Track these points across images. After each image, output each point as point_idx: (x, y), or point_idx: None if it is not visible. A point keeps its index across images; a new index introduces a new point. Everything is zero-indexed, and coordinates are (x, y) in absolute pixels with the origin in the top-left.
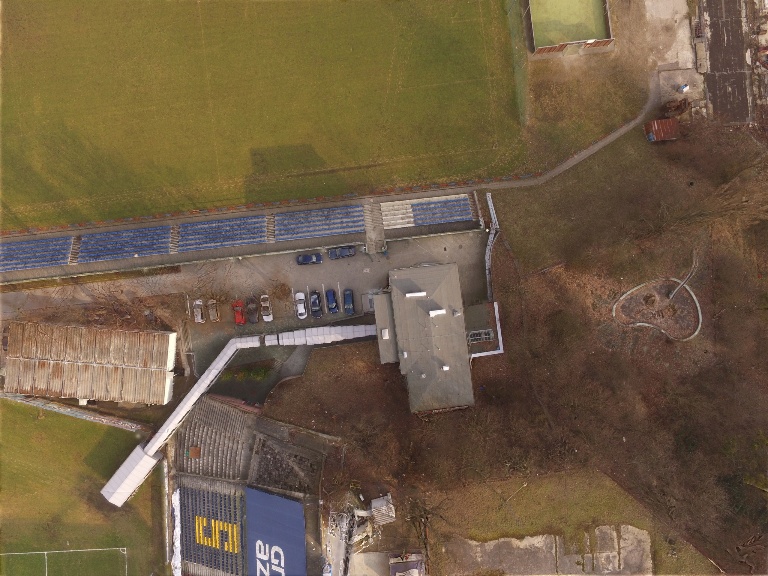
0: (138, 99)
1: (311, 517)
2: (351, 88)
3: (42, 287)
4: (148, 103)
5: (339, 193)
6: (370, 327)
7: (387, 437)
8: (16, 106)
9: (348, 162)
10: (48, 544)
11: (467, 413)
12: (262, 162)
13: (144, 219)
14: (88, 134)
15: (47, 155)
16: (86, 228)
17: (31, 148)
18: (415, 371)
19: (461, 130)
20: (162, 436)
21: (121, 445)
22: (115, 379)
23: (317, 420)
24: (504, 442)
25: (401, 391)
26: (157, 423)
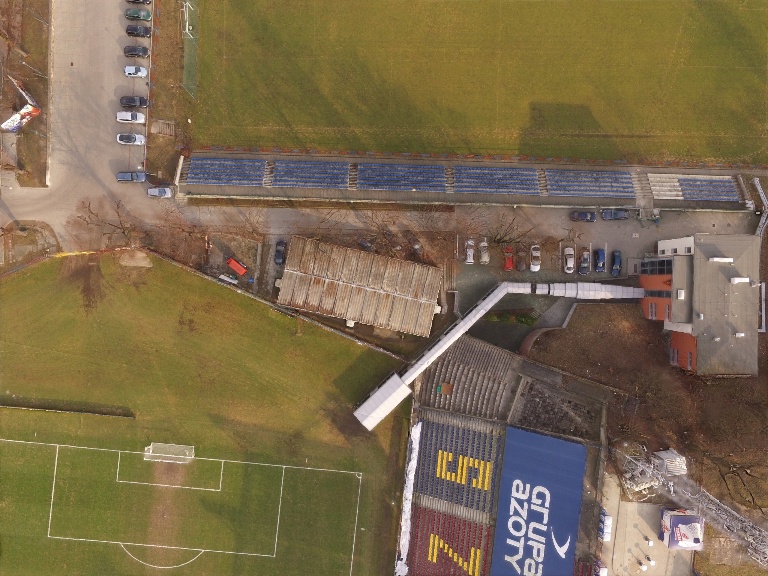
0: (430, 39)
1: (590, 461)
2: (635, 58)
3: (320, 207)
4: (439, 44)
5: (609, 158)
6: (638, 290)
7: (681, 393)
8: (313, 29)
9: (622, 129)
10: (287, 459)
11: (737, 384)
12: (540, 117)
13: (419, 156)
14: (378, 66)
15: (335, 81)
16: (362, 157)
17: (321, 72)
18: (707, 334)
19: (733, 114)
20: (421, 367)
21: (371, 372)
22: (385, 306)
23: (592, 370)
24: None
25: (663, 355)
26: (408, 356)
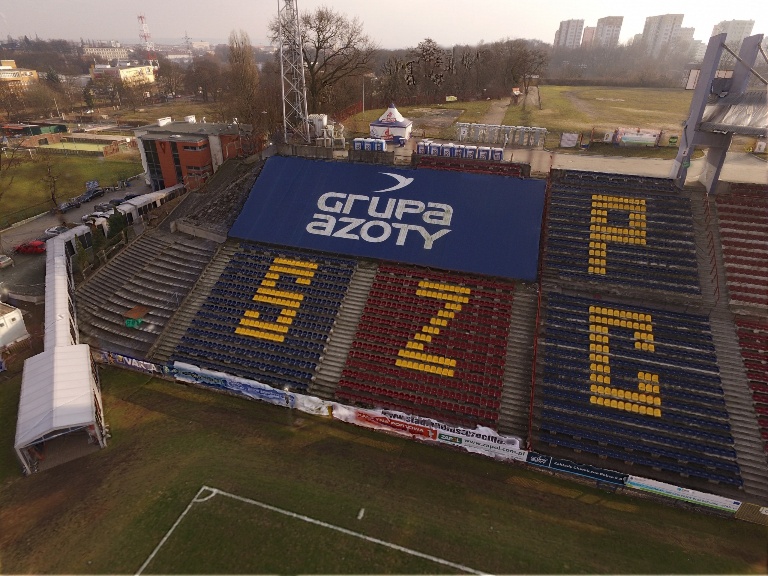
0: None
1: None
2: None
3: None
4: None
5: None
6: (173, 186)
7: None
8: None
9: (31, 204)
10: None
11: None
12: None
13: None
14: None
15: None
16: None
17: None
18: None
19: (102, 174)
20: (58, 325)
21: None
22: None
23: None
24: (311, 106)
25: None
26: None
